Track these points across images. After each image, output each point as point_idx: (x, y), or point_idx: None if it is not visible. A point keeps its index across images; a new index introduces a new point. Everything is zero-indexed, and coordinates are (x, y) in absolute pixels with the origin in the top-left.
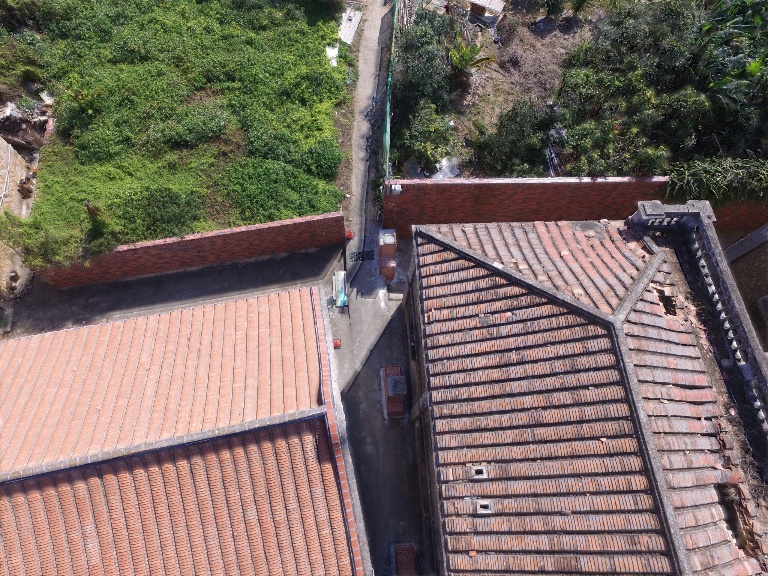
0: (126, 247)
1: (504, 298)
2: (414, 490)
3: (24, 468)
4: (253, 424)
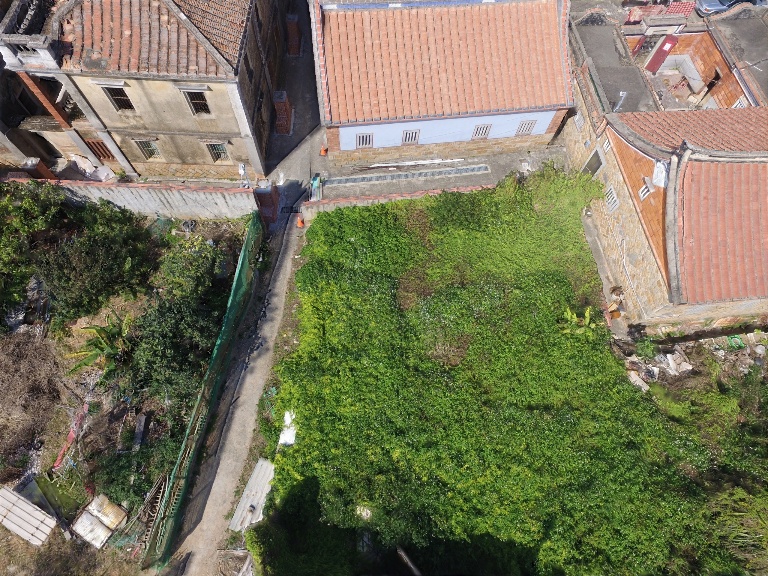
0: (489, 186)
1: (187, 3)
2: (282, 76)
3: (487, 6)
4: (361, 0)
